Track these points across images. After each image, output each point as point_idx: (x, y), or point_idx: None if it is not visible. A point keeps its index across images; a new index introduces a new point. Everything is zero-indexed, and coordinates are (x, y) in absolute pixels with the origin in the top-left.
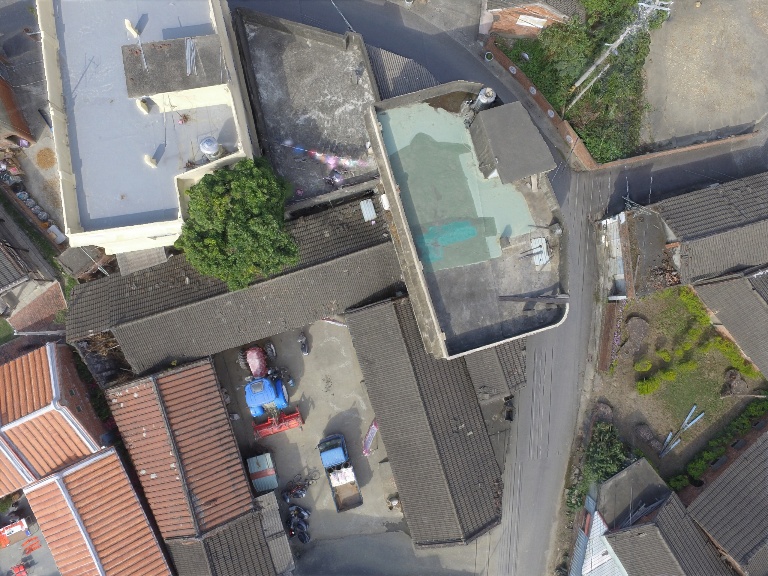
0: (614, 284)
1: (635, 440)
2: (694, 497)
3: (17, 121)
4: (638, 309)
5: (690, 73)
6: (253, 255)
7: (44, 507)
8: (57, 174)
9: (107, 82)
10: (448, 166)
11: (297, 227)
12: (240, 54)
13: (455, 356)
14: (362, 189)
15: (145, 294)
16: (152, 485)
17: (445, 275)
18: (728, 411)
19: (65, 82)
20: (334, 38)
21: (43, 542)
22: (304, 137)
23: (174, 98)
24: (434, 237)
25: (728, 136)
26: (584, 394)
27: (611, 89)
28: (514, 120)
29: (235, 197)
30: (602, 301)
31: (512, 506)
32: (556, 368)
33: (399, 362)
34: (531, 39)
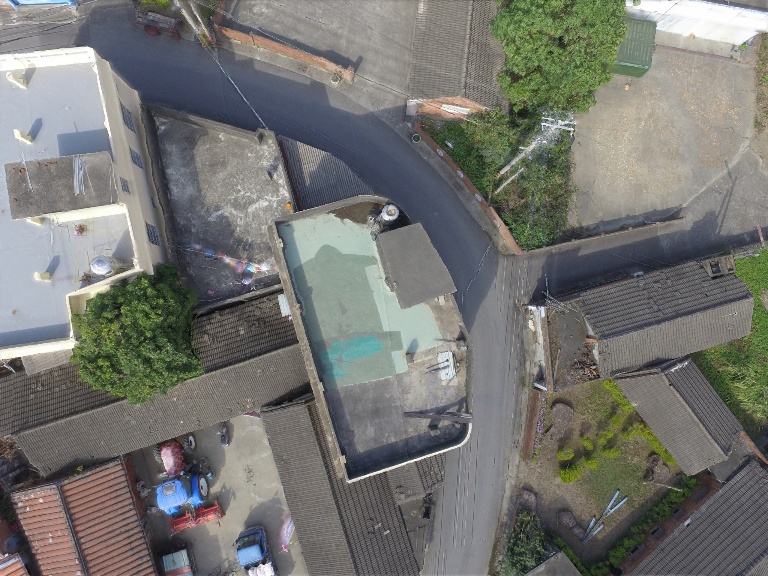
0: (540, 369)
1: (559, 526)
2: None
3: None
4: (563, 394)
5: (618, 157)
6: (146, 380)
7: None
8: None
9: None
10: (354, 279)
11: (212, 322)
12: (148, 149)
13: (355, 479)
14: (276, 288)
15: (51, 396)
16: None
17: (349, 391)
18: (651, 496)
19: None
20: (245, 135)
21: None
22: (216, 235)
23: (65, 214)
24: (338, 352)
25: (654, 221)
26: (509, 480)
27: (534, 180)
28: (414, 243)
29: (125, 323)
30: (528, 386)
31: None
32: (481, 454)
33: (313, 464)
34: (458, 122)
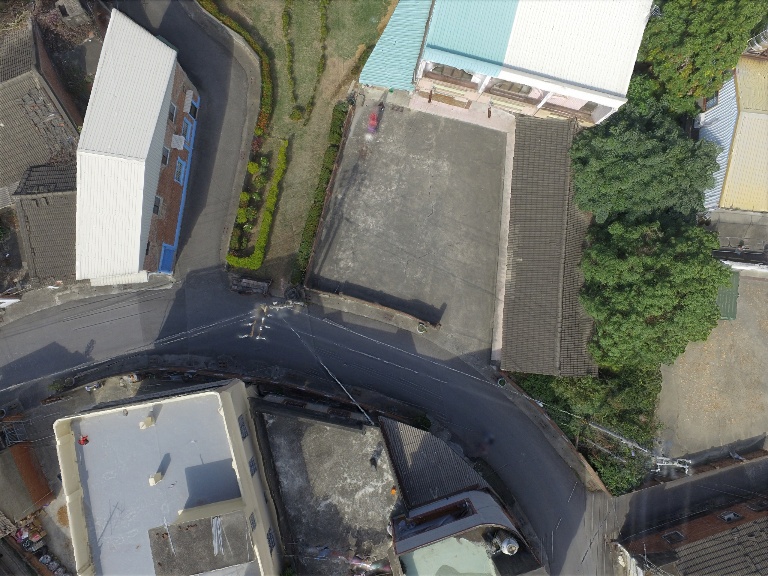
0: None
1: None
2: None
3: (37, 490)
4: None
5: (701, 390)
6: None
7: None
8: None
9: (132, 528)
10: None
11: None
12: (259, 447)
13: None
14: None
15: None
16: None
17: None
18: None
19: (90, 531)
20: None
21: None
22: (325, 524)
23: None
24: None
25: (740, 455)
26: None
27: None
28: None
29: None
30: None
31: None
32: None
33: None
34: None
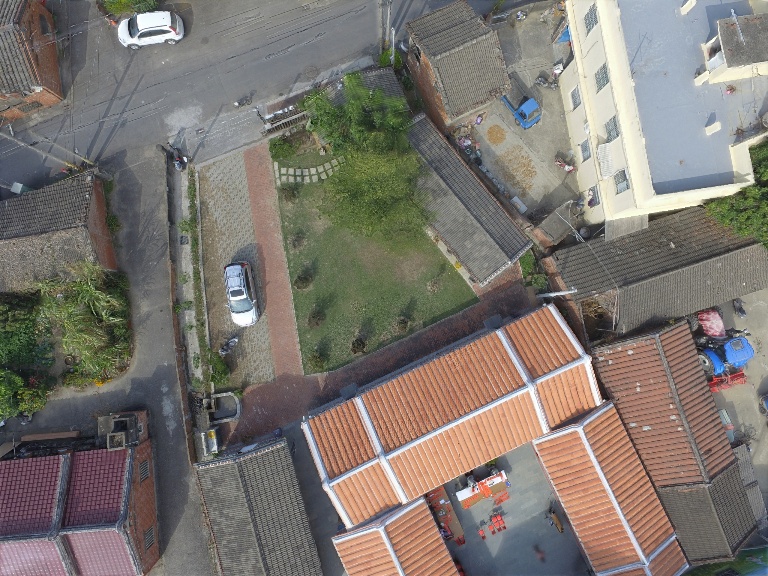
0: None
1: None
2: None
3: None
4: None
5: None
6: None
7: (556, 456)
8: (506, 149)
9: (660, 56)
10: None
11: None
12: None
13: None
14: None
15: (634, 258)
16: (643, 437)
17: None
18: None
19: None
20: None
21: (511, 494)
22: None
23: None
24: None
25: None
26: None
27: None
28: None
29: None
30: None
31: None
32: None
33: None
34: None
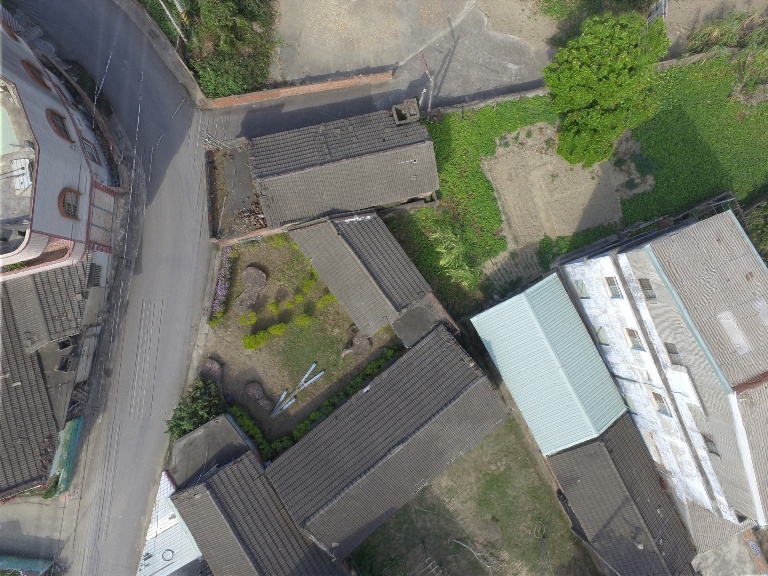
0: None
1: (247, 399)
2: (277, 458)
3: None
4: (259, 259)
5: (328, 8)
6: None
7: None
8: None
9: None
10: None
11: None
12: None
13: None
14: None
15: None
16: None
17: None
18: (351, 370)
19: None
20: None
21: None
22: None
23: None
24: None
25: None
26: (197, 349)
27: (205, 14)
28: None
29: None
30: None
31: (107, 468)
32: (165, 320)
33: None
34: None
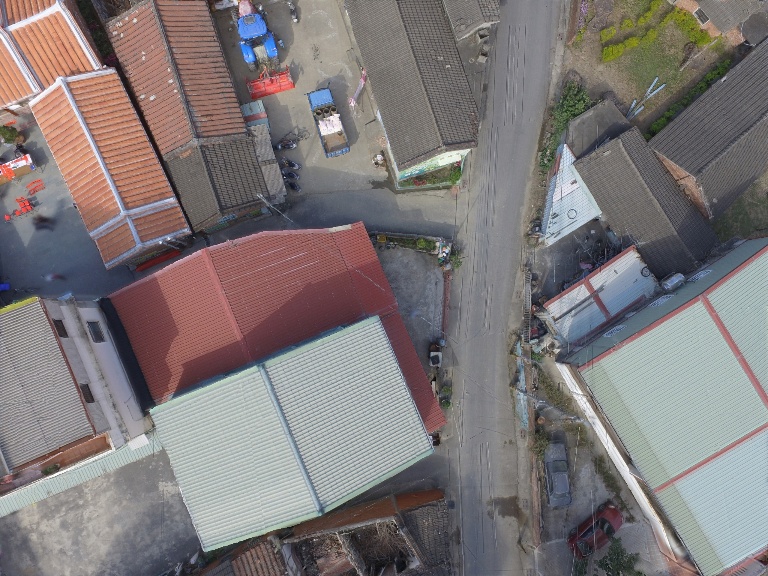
0: None
1: None
2: (655, 135)
3: None
4: None
5: None
6: None
7: (49, 117)
8: None
9: None
10: None
11: None
12: None
13: None
14: None
15: None
16: (151, 107)
17: None
18: (687, 83)
19: None
20: None
21: (47, 184)
22: None
23: None
24: None
25: None
26: (555, 68)
27: None
28: None
29: None
30: None
31: (489, 166)
32: (529, 43)
33: None
34: None
